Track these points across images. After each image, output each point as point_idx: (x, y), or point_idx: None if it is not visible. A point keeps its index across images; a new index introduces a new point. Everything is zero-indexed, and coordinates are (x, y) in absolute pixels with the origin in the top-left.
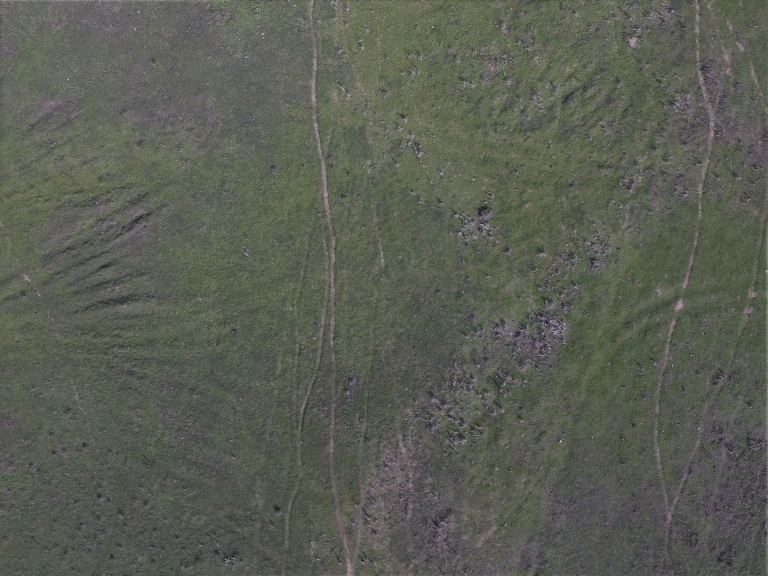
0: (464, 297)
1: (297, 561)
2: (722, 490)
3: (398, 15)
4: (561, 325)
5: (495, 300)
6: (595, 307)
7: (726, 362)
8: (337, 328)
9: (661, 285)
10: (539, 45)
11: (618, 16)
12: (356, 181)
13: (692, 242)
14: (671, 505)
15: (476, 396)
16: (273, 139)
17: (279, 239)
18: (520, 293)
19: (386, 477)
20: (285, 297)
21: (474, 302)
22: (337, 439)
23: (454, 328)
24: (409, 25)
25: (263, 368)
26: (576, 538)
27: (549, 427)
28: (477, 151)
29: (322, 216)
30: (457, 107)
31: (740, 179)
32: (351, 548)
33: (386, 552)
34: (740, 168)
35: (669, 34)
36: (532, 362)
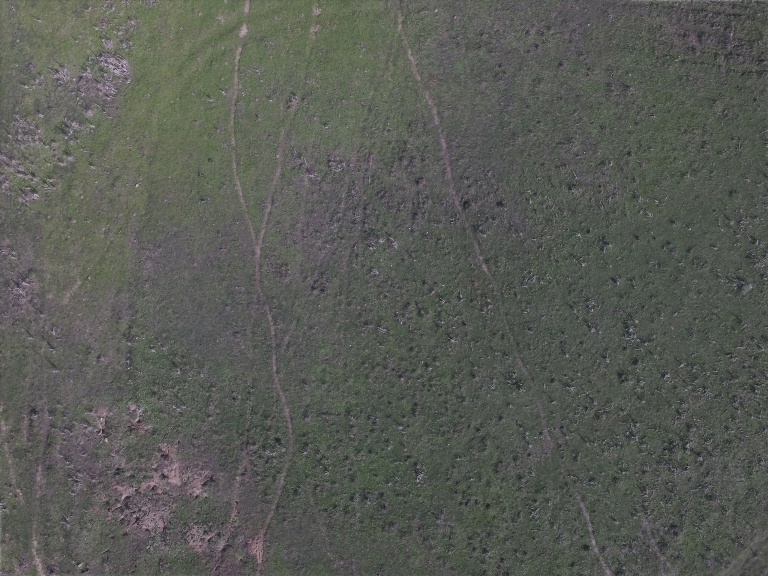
0: (19, 46)
1: None
2: (308, 216)
3: None
4: (121, 63)
5: (51, 45)
6: (155, 41)
7: (298, 84)
8: None
9: (222, 12)
10: None
11: None
12: None
13: None
14: (258, 238)
15: (44, 148)
16: None
17: None
18: (77, 35)
19: None
20: None
21: (30, 50)
22: None
23: (14, 80)
24: None
25: None
26: (165, 284)
27: (123, 172)
28: None
29: None
30: None
31: None
32: None
33: None
34: None
35: None
36: (98, 106)
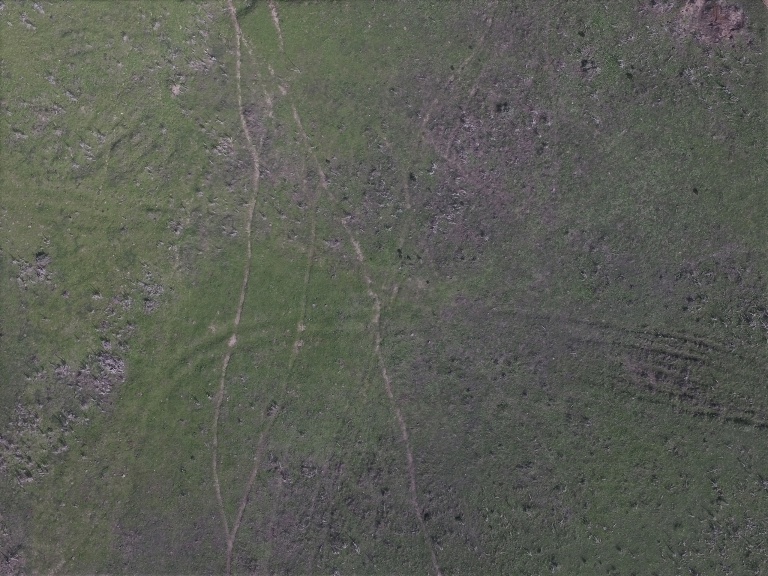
0: (25, 340)
1: None
2: (279, 517)
3: None
4: (118, 364)
5: (55, 342)
6: (151, 345)
7: (279, 394)
8: None
9: (214, 322)
10: (86, 95)
11: (162, 64)
12: None
13: (242, 279)
14: (231, 533)
15: (41, 435)
16: None
17: None
18: (79, 334)
19: None
20: None
21: (35, 344)
22: None
23: (19, 370)
24: None
25: None
26: (143, 568)
27: (112, 462)
28: (33, 199)
29: None
30: (11, 157)
31: (285, 217)
32: None
33: None
34: (286, 207)
35: (212, 80)
36: (93, 400)
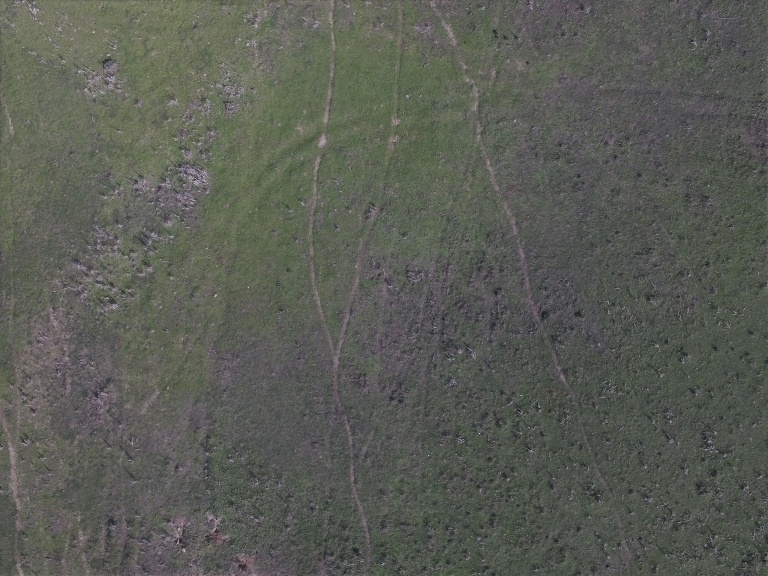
0: (98, 156)
1: None
2: (386, 327)
3: None
4: (200, 174)
5: (130, 156)
6: (235, 152)
7: (376, 195)
8: None
9: (301, 122)
10: None
11: None
12: None
13: (328, 74)
14: (336, 348)
15: (122, 258)
16: None
17: None
18: (156, 146)
19: (41, 353)
20: None
21: (109, 160)
22: None
23: (93, 190)
24: None
25: None
26: (243, 394)
27: (202, 282)
28: (95, 2)
29: None
30: None
31: (370, 4)
32: (11, 431)
33: (48, 431)
34: None
35: None
36: (177, 216)
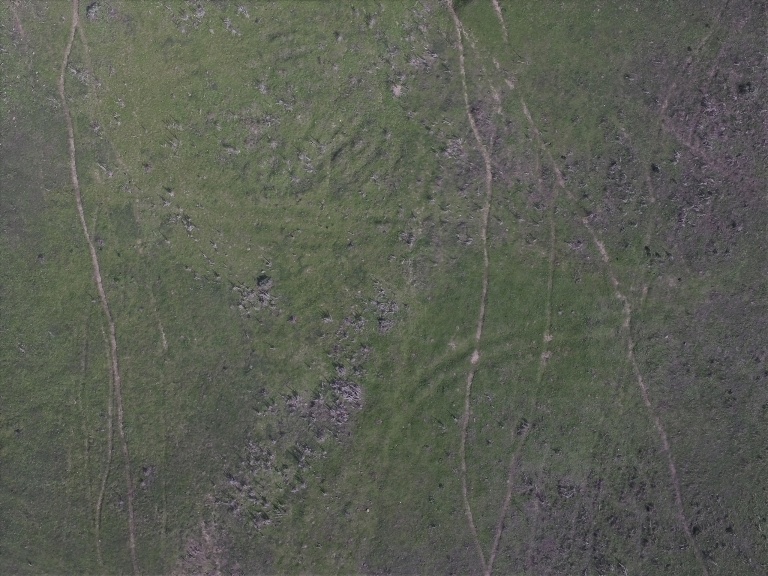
0: (252, 372)
1: None
2: (538, 542)
3: (152, 85)
4: (354, 391)
5: (284, 372)
6: (388, 368)
7: (529, 410)
8: (125, 417)
9: (454, 338)
10: (301, 103)
11: (380, 65)
12: (128, 262)
13: (481, 290)
14: (488, 563)
15: (275, 473)
16: (37, 227)
17: (55, 331)
18: (310, 362)
19: (192, 567)
20: (67, 391)
21: (263, 376)
22: (137, 533)
23: (246, 405)
24: (165, 95)
25: (52, 467)
26: None
27: (354, 497)
28: (250, 219)
29: (97, 302)
30: (224, 175)
31: (523, 221)
32: None
33: None
34: (522, 209)
35: (435, 79)
36: (330, 432)
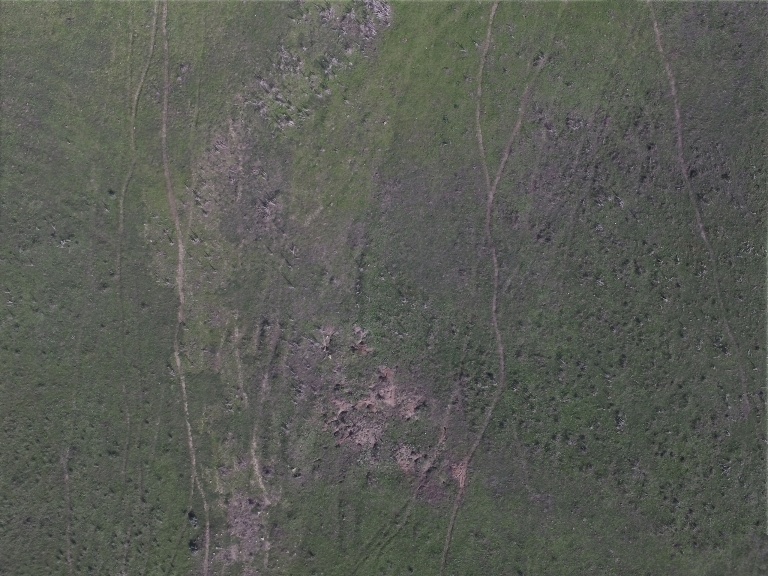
0: None
1: (131, 243)
2: (542, 169)
3: None
4: (385, 7)
5: None
6: None
7: (546, 44)
8: (169, 16)
9: None
10: None
11: None
12: None
13: None
14: (492, 184)
15: (303, 79)
16: None
17: None
18: None
19: (217, 161)
20: None
21: None
22: (169, 124)
23: (282, 13)
24: None
25: (98, 56)
26: (401, 218)
27: (374, 109)
28: None
29: None
30: None
31: None
32: (183, 229)
33: (217, 233)
34: None
35: None
36: (357, 45)
